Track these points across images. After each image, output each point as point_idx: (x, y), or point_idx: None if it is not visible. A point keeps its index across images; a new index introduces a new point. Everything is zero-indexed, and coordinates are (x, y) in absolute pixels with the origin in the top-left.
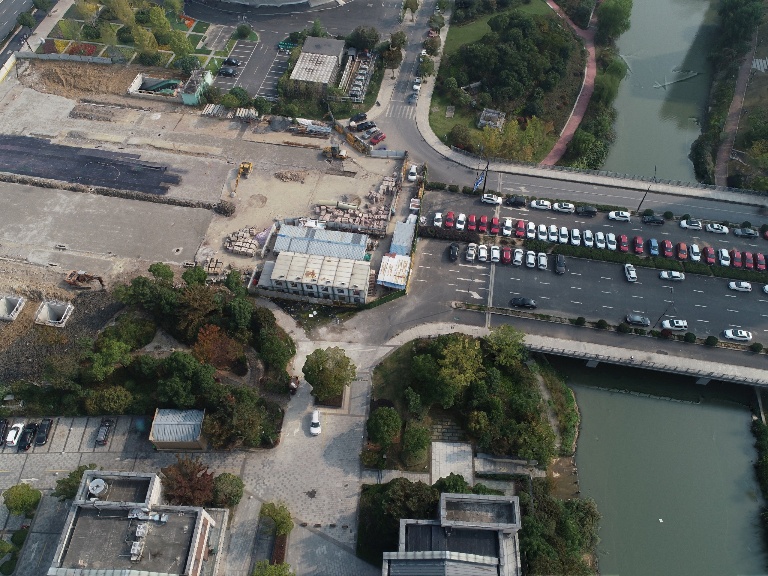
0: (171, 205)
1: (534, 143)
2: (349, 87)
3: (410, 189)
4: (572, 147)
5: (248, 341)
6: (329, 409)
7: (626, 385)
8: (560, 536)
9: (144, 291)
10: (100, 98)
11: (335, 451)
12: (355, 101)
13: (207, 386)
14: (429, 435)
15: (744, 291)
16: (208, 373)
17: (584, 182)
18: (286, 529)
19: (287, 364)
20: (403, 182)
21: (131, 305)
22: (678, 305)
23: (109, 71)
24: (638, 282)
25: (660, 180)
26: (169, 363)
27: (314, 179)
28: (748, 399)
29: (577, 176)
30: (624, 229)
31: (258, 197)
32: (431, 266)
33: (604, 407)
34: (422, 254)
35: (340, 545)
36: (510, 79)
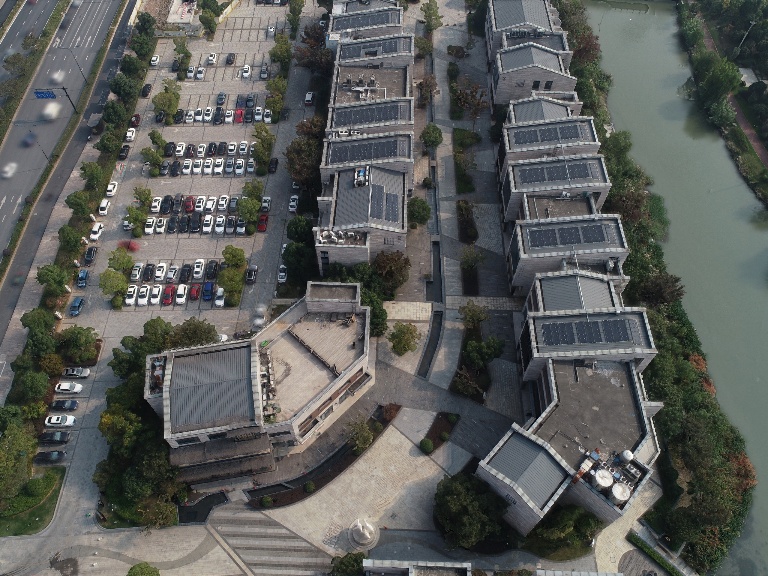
0: None
1: None
2: None
3: None
4: None
5: None
6: None
7: (607, 2)
8: None
9: None
10: None
11: (451, 4)
12: None
13: None
14: None
15: None
16: None
17: None
18: (436, 7)
19: None
20: None
21: None
22: None
23: None
24: None
25: None
26: None
27: None
28: None
29: None
30: None
31: None
32: None
33: (595, 2)
34: None
35: (460, 31)
36: None
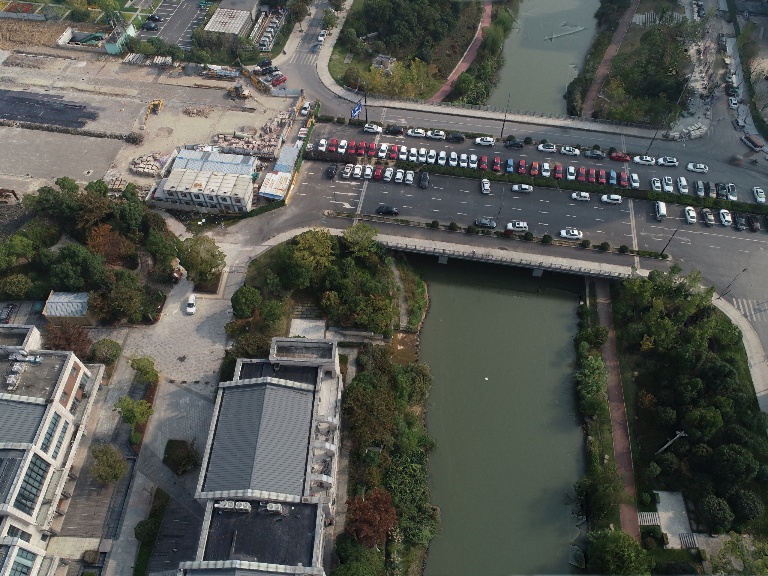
0: (87, 136)
1: (419, 83)
2: (260, 39)
3: (302, 122)
4: (453, 87)
5: (140, 241)
6: (206, 295)
7: (478, 282)
8: (391, 389)
9: (47, 197)
10: (32, 49)
11: (207, 326)
12: (263, 50)
13: (95, 270)
14: (290, 314)
15: (584, 200)
16: (96, 260)
17: (459, 115)
18: (148, 375)
19: (173, 260)
20: (297, 116)
21: (38, 212)
22: (524, 212)
23: (42, 26)
24: (492, 194)
25: (526, 112)
26: (63, 252)
27: (217, 114)
28: (579, 289)
29: (453, 110)
30: (487, 152)
31: (165, 129)
32: (311, 183)
33: (452, 296)
34: (305, 173)
35: (201, 396)
36: (401, 28)
